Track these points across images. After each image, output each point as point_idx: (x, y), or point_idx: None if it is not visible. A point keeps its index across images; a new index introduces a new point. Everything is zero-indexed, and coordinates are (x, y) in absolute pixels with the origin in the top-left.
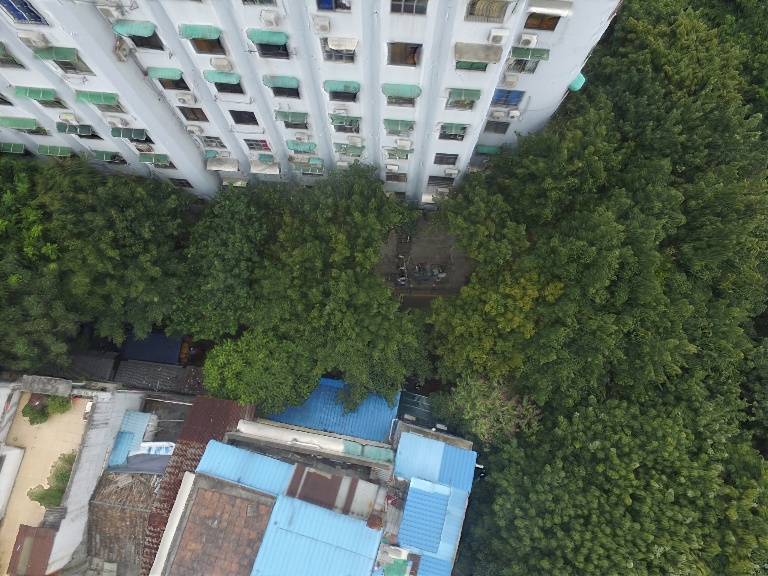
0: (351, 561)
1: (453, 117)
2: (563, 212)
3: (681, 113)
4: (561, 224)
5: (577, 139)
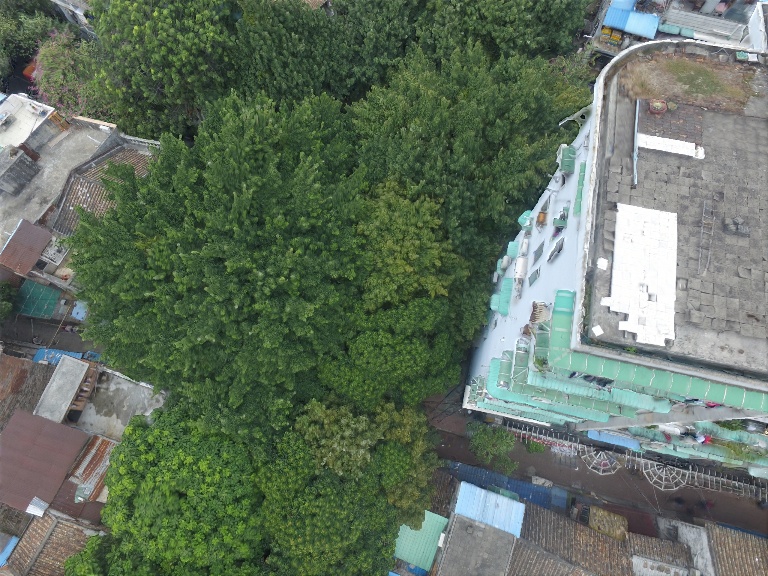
0: None
1: None
2: None
3: None
4: None
5: None
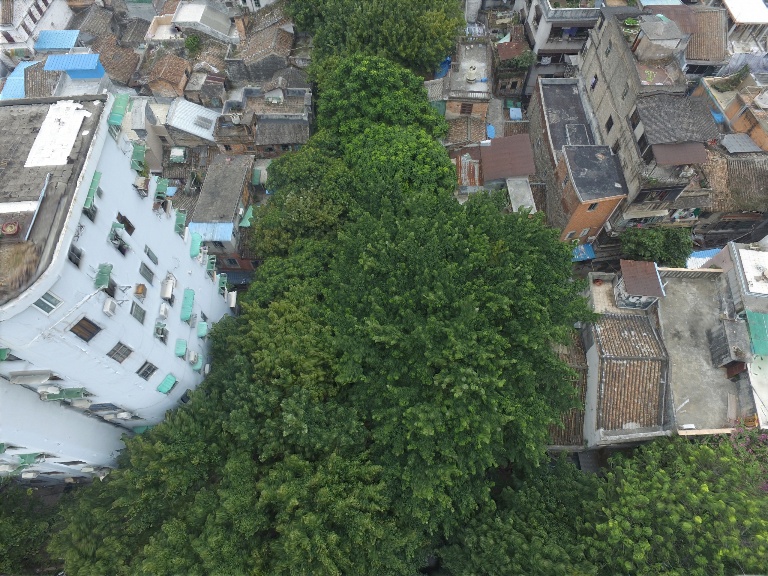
0: None
1: (20, 451)
2: (167, 515)
3: None
4: (153, 536)
5: (148, 452)
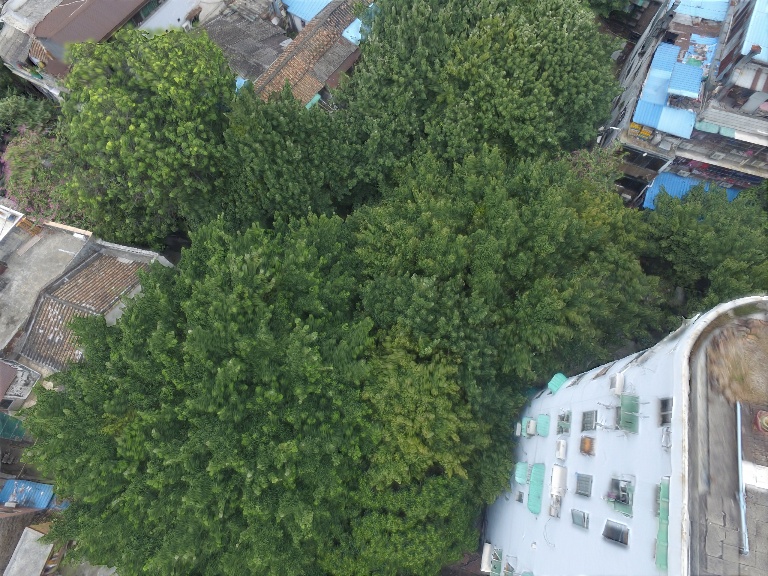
0: (760, 41)
1: None
2: None
3: (457, 329)
4: None
5: None
